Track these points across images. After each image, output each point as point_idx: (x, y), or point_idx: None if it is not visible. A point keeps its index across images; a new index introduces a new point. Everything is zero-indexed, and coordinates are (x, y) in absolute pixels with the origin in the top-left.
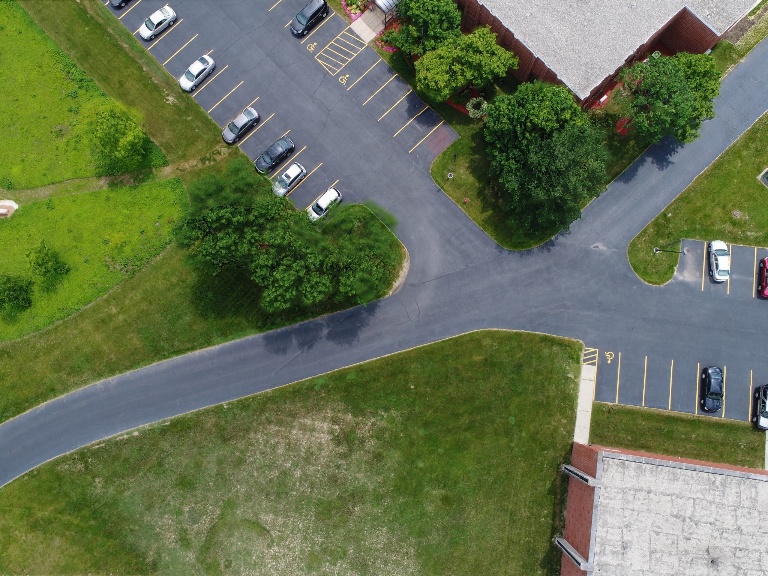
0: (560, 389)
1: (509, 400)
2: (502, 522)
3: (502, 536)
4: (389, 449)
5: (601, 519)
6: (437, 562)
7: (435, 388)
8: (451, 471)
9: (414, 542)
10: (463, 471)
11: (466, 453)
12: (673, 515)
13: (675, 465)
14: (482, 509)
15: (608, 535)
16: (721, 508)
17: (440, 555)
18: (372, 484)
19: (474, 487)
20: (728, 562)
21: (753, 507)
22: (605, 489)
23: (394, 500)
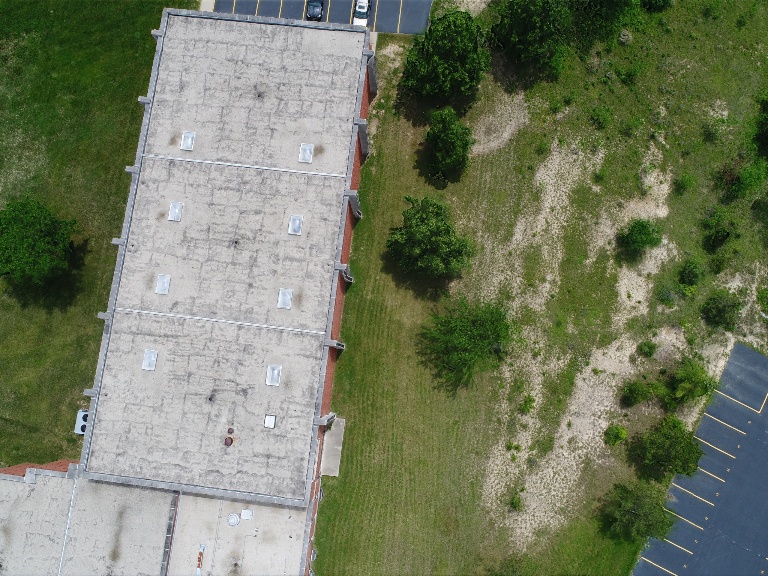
0: (182, 7)
1: (136, 18)
2: (123, 119)
3: (123, 131)
4: (28, 64)
5: (164, 65)
6: (64, 155)
7: (71, 11)
8: (81, 79)
9: (45, 140)
10: (92, 79)
11: (95, 64)
12: (227, 59)
13: (229, 16)
14: (106, 109)
15: (169, 77)
16: (270, 52)
17: (67, 149)
18: (11, 94)
19: (100, 91)
20: (272, 95)
21: (298, 50)
22: (169, 41)
23: (30, 106)
